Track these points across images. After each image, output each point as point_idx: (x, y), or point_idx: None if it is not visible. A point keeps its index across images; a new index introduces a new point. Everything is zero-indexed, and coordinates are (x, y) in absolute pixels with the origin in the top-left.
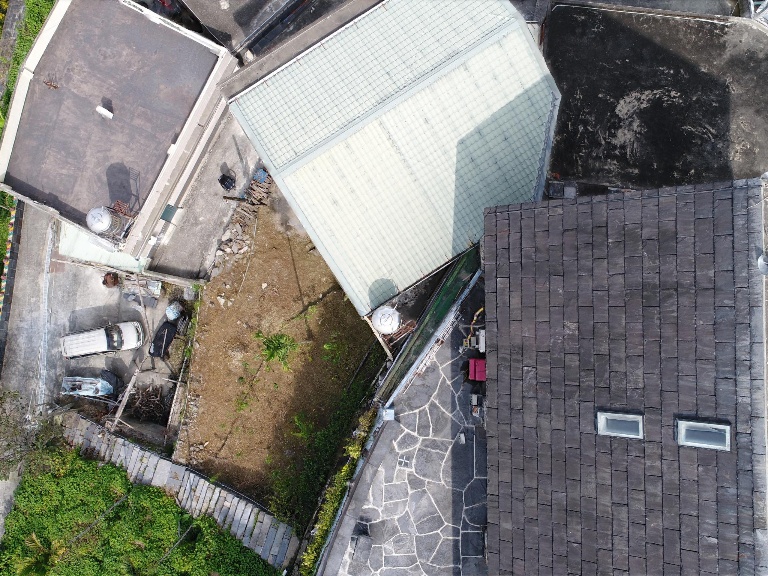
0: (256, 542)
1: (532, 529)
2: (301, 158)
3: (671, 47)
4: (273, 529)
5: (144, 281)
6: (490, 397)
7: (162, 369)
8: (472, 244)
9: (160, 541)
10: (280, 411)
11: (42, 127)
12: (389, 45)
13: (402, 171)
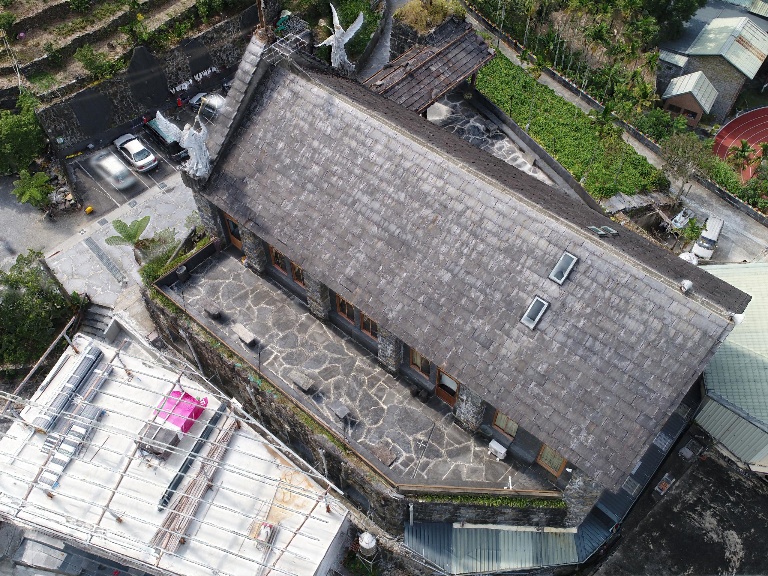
0: None
1: None
2: None
3: None
4: None
5: None
6: None
7: None
8: None
9: None
10: None
11: None
12: None
13: None
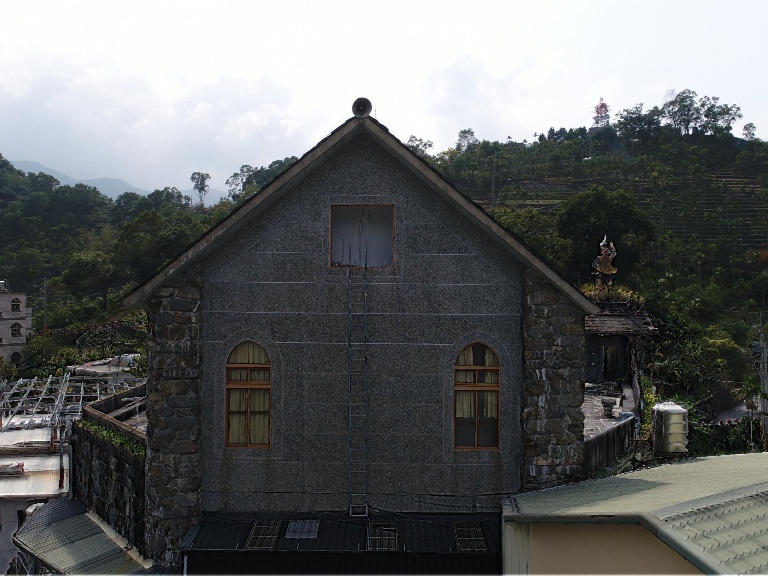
0: None
1: None
2: None
3: None
4: None
5: None
6: None
7: None
8: None
9: None
10: None
11: None
12: None
13: None
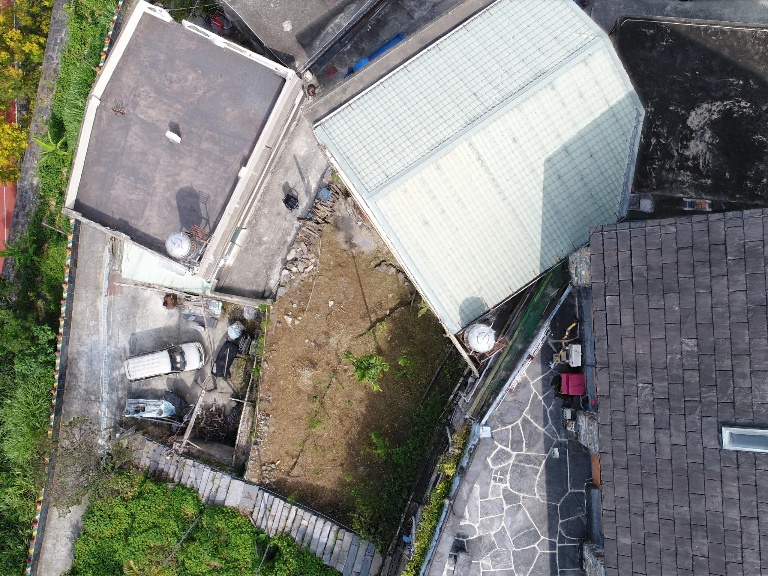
0: (337, 560)
1: (653, 544)
2: (393, 181)
3: (740, 58)
4: (354, 546)
5: (204, 301)
6: (602, 414)
7: (224, 388)
8: (559, 260)
9: (236, 561)
10: (352, 428)
11: (110, 153)
12: (474, 66)
13: (491, 190)
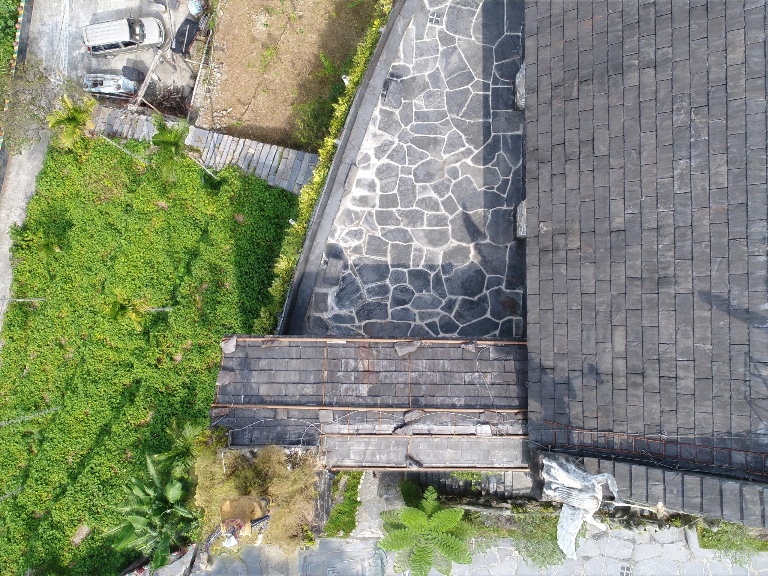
0: (281, 177)
1: None
2: None
3: None
4: (298, 161)
5: None
6: None
7: (183, 70)
8: None
9: (183, 200)
10: (304, 69)
11: None
12: None
13: None
